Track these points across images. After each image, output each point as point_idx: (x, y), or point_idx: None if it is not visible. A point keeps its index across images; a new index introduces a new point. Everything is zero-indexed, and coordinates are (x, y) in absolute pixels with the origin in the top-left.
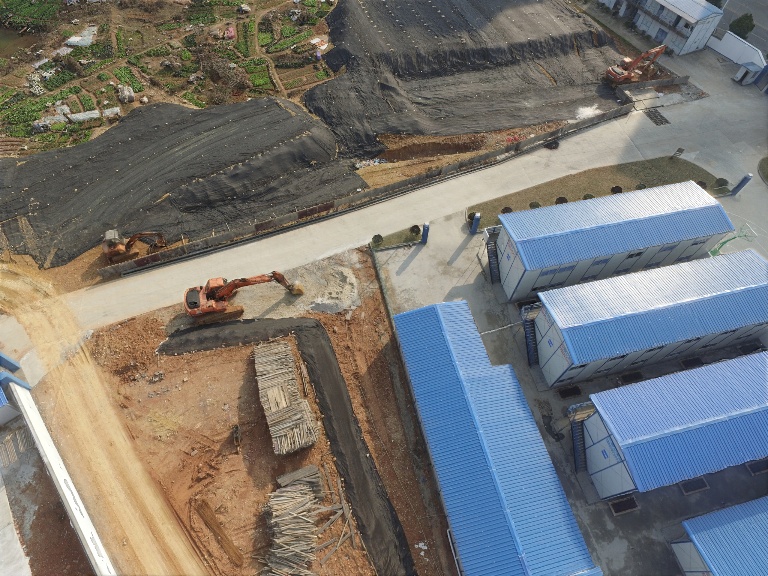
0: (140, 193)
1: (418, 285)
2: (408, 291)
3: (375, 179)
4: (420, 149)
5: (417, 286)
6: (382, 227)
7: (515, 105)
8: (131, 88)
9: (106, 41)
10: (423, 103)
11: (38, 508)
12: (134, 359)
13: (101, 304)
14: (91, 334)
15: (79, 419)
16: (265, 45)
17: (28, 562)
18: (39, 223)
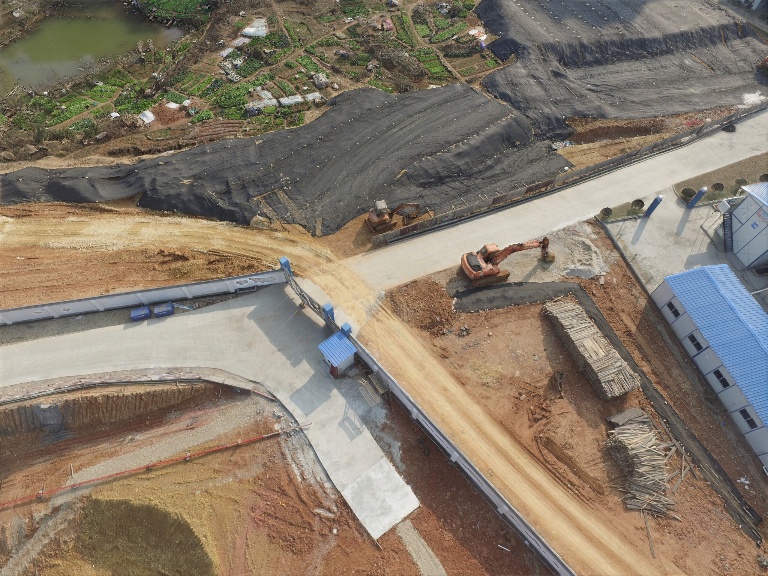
0: (378, 169)
1: (656, 254)
2: (649, 259)
3: (577, 159)
4: (604, 132)
5: (655, 254)
6: (601, 202)
7: (683, 91)
8: (324, 75)
9: (280, 32)
10: (595, 90)
11: (401, 444)
12: (439, 315)
13: (381, 268)
14: (384, 294)
15: (408, 368)
16: (426, 36)
17: (411, 490)
18: (296, 196)
